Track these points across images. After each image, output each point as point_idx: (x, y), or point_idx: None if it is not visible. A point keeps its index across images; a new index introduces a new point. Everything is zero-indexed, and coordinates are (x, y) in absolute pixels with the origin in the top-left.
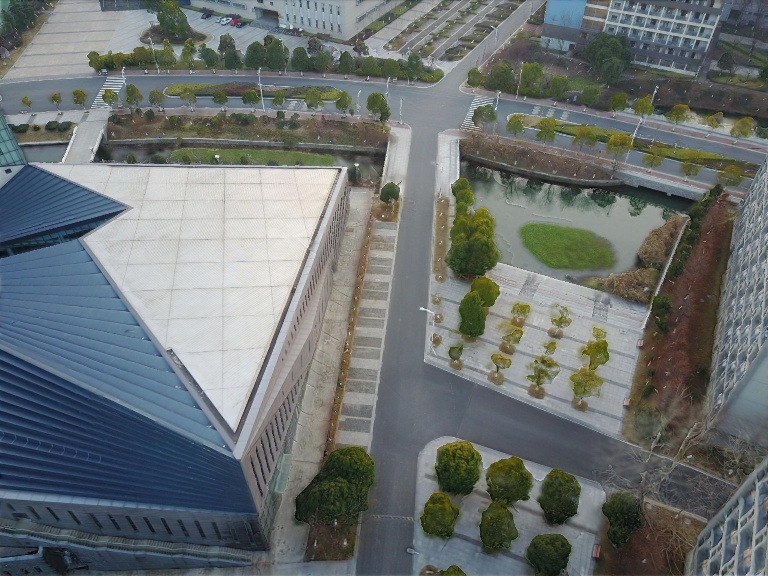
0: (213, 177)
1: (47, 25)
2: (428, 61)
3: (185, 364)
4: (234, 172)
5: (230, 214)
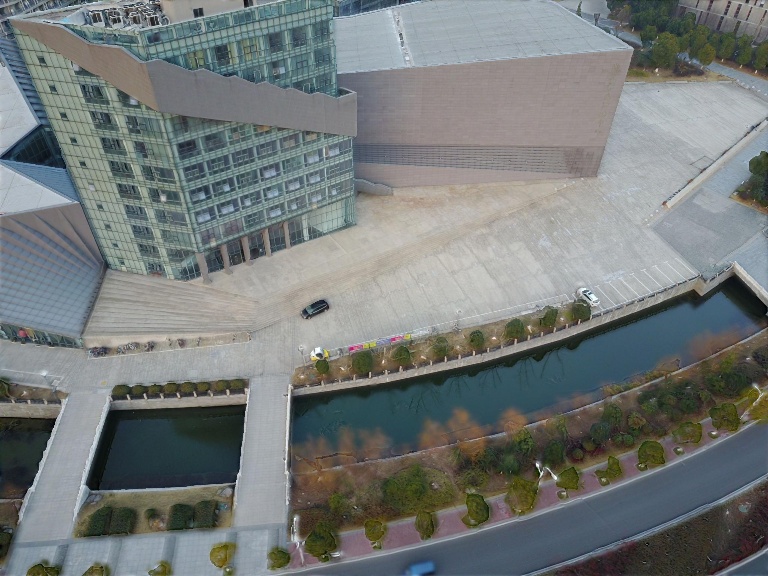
0: None
1: None
2: None
3: None
4: None
5: None
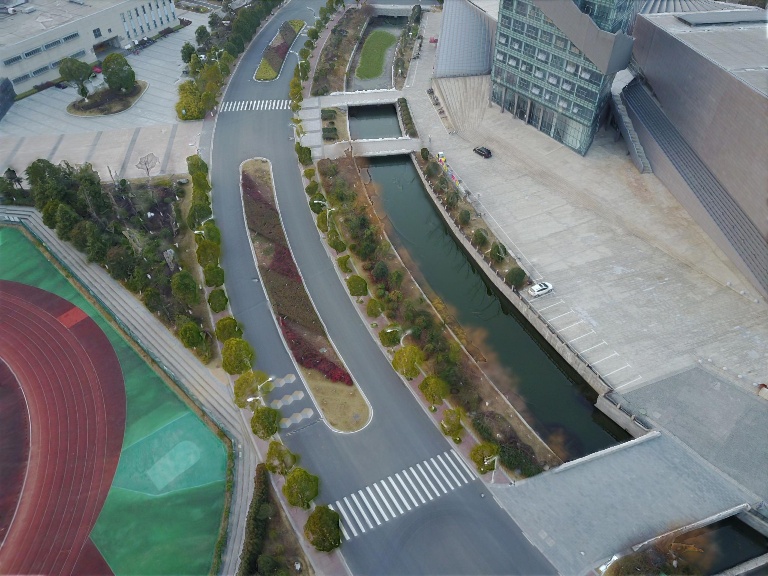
0: None
1: None
2: None
3: None
4: None
5: None
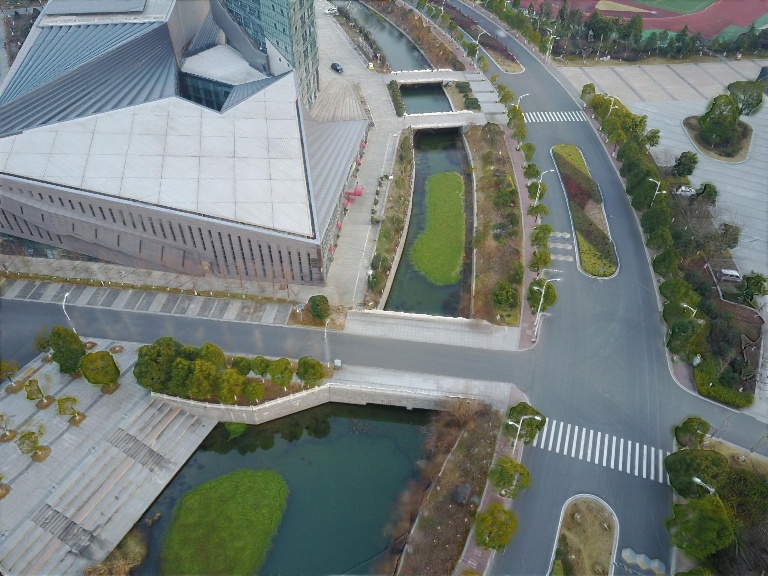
0: (282, 152)
1: (692, 65)
2: (752, 373)
3: (3, 138)
4: (295, 164)
5: (208, 160)
